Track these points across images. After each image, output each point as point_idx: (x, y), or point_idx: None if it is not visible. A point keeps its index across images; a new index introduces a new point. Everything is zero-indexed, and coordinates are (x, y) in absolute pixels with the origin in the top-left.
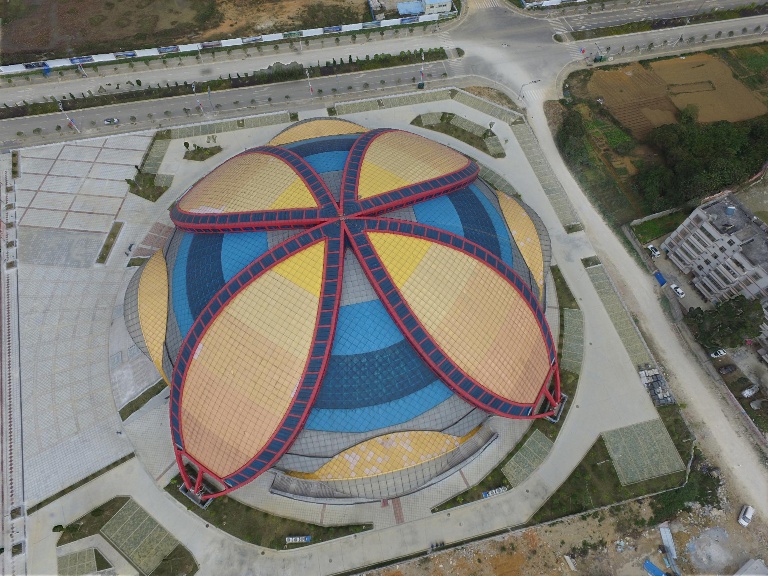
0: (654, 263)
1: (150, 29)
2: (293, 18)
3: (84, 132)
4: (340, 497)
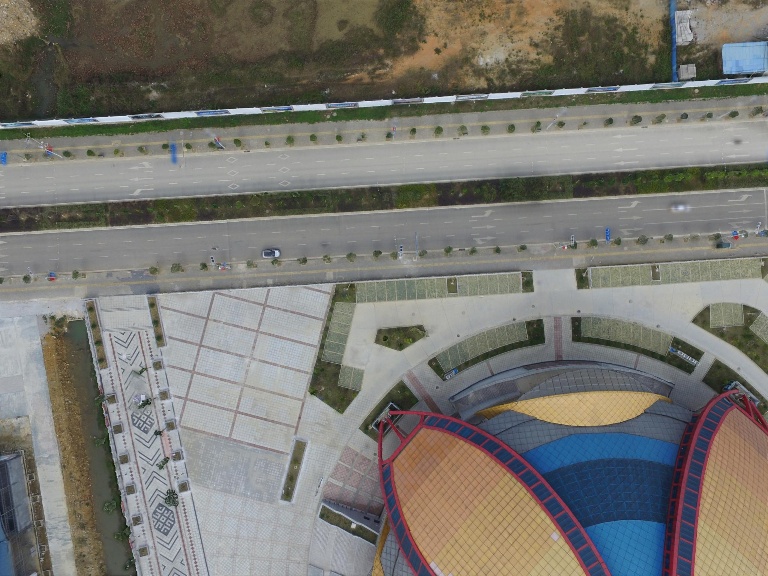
0: None
1: (306, 37)
2: (539, 45)
3: (235, 268)
4: None
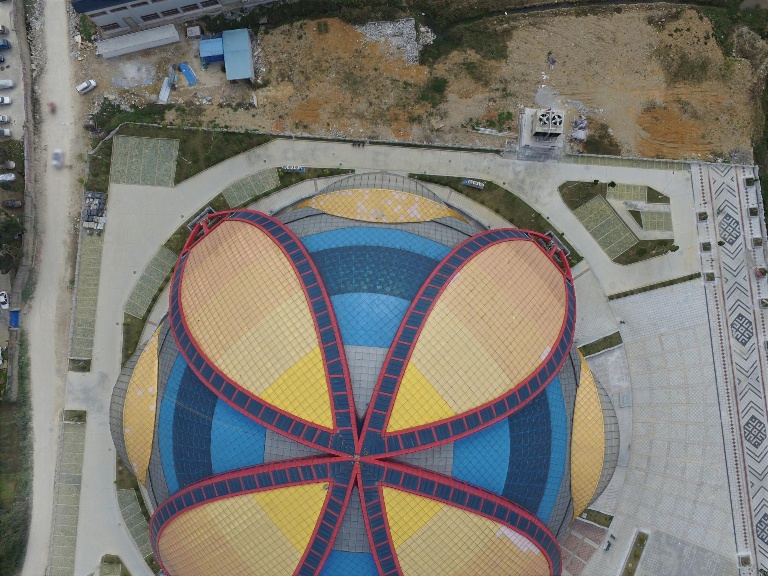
0: (8, 341)
1: None
2: None
3: None
4: None
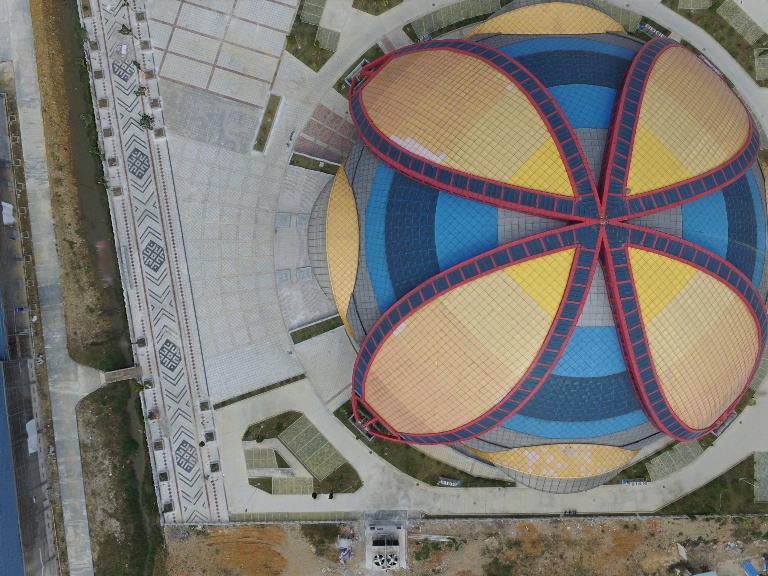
0: None
1: None
2: None
3: None
4: None
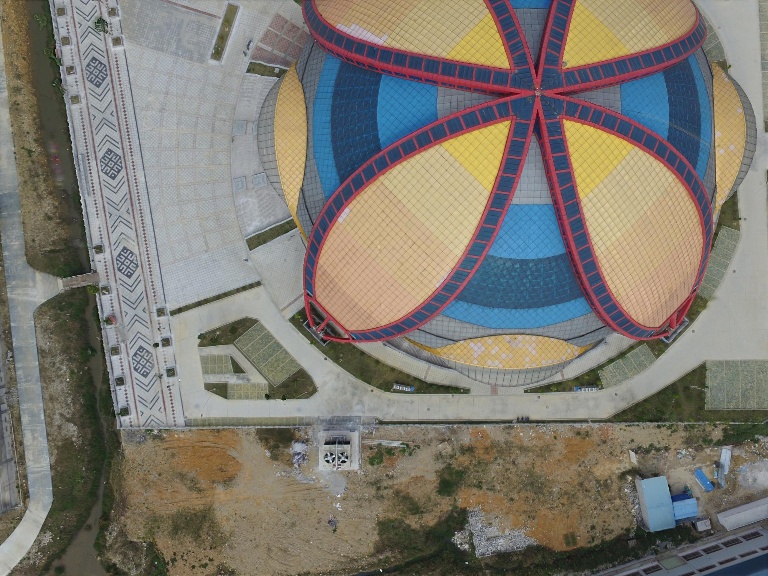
0: None
1: None
2: None
3: None
4: (450, 368)
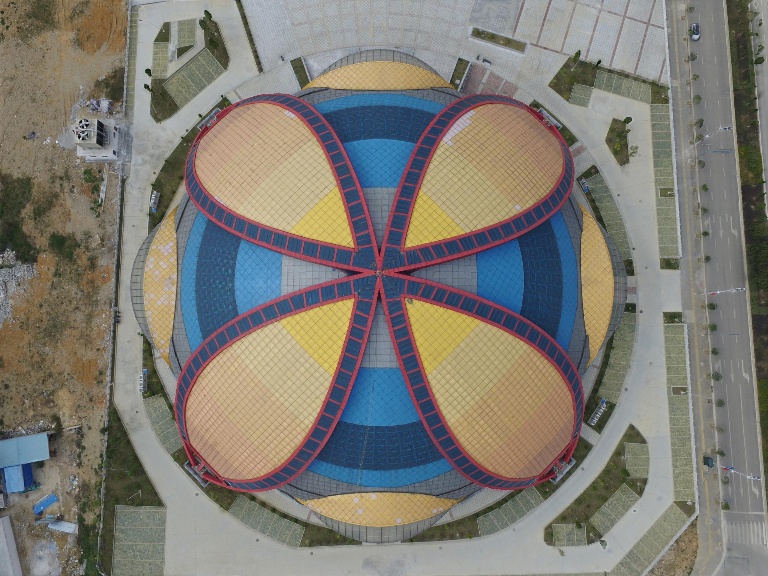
0: None
1: None
2: None
3: (681, 2)
4: None
